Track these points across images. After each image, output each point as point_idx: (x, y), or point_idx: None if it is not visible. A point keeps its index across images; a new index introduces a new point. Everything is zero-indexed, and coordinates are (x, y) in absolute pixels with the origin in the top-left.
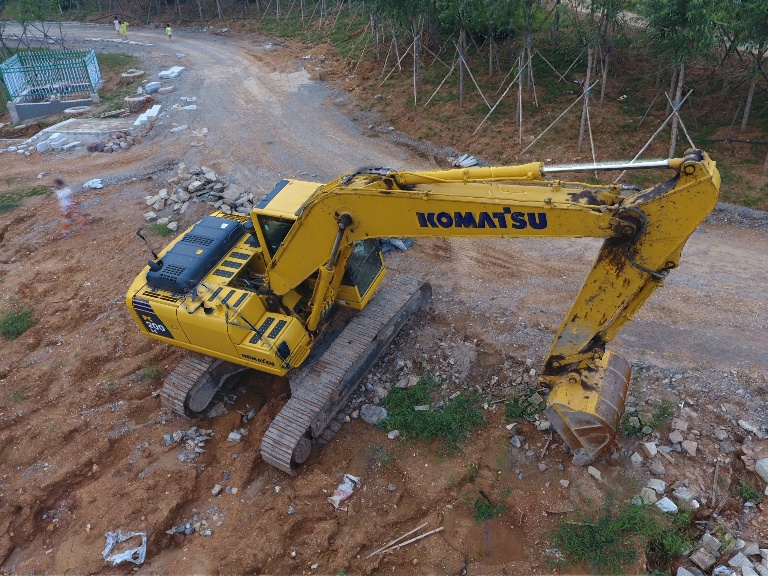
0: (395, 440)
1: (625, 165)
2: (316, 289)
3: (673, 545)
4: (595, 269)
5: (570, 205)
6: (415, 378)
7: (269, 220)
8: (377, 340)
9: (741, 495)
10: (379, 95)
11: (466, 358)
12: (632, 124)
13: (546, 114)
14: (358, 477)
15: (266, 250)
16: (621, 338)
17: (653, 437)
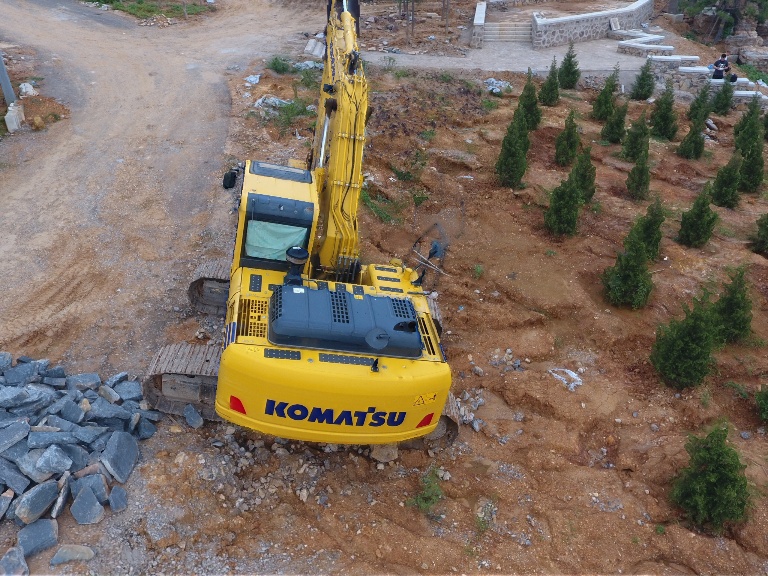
0: None
1: None
2: None
3: None
4: None
5: None
6: None
7: None
8: None
9: None
10: None
11: None
12: None
13: None
14: None
15: None
16: (198, 213)
17: None
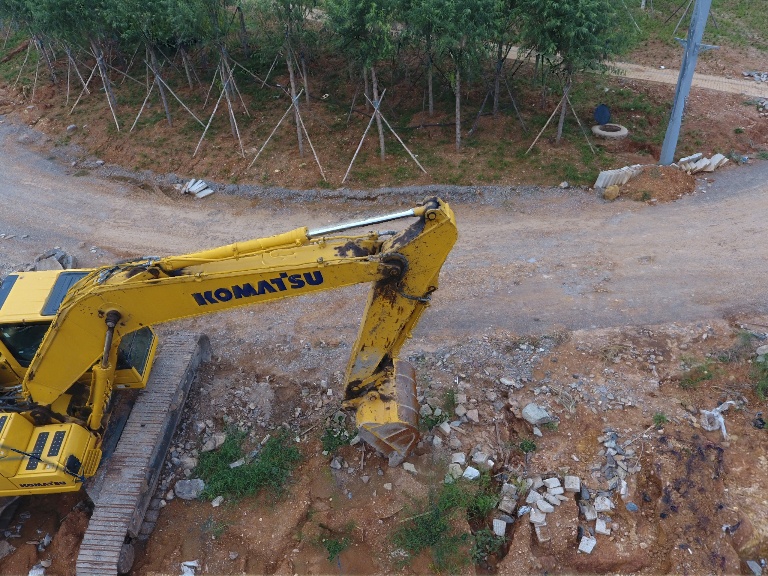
0: (221, 506)
1: (379, 219)
2: (92, 389)
3: (485, 505)
4: (372, 306)
5: (340, 260)
6: (221, 436)
7: (8, 327)
8: (170, 411)
9: (523, 449)
10: (72, 126)
11: (265, 399)
12: (341, 122)
13: (260, 123)
14: (196, 560)
15: (11, 358)
16: None
17: (444, 417)
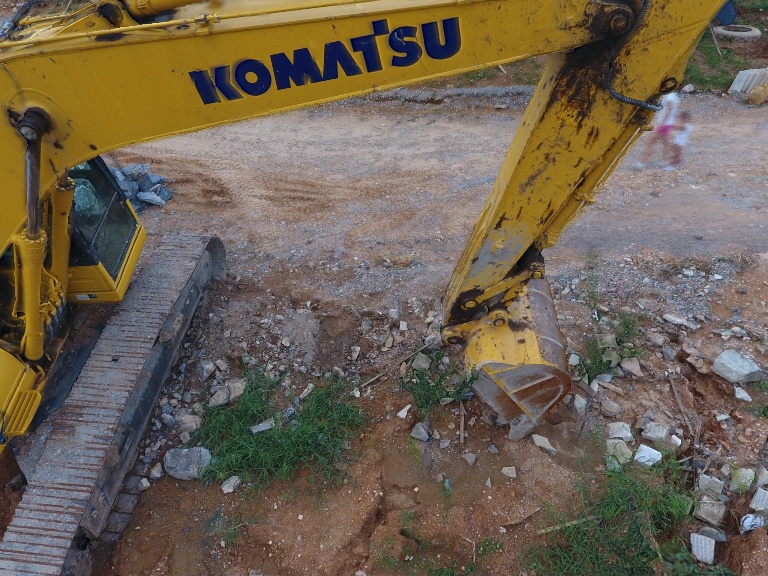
0: (236, 493)
1: None
2: (18, 283)
3: (681, 510)
4: (541, 122)
5: None
6: (238, 384)
7: None
8: (160, 343)
9: None
10: None
11: (306, 332)
12: None
13: None
14: None
15: None
16: None
17: None
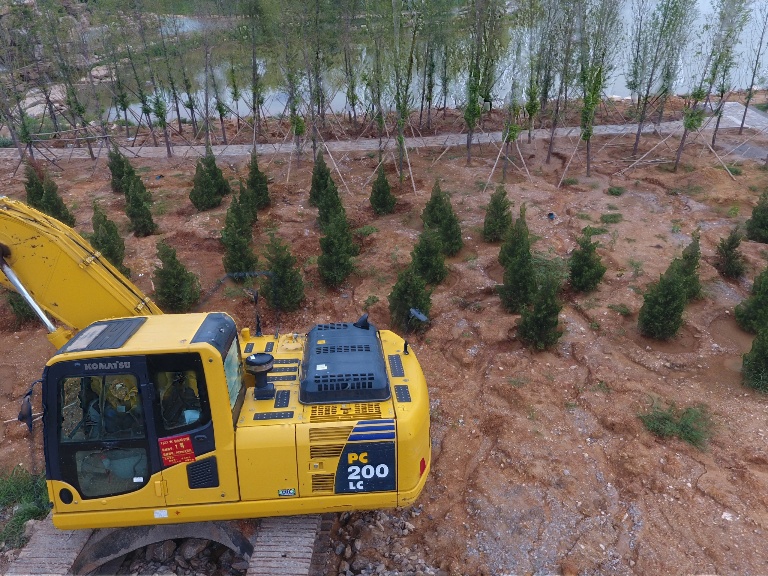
0: None
1: None
2: None
3: None
4: None
5: None
6: (31, 522)
7: None
8: None
9: None
10: None
11: None
12: None
13: None
14: None
15: None
16: None
17: None
